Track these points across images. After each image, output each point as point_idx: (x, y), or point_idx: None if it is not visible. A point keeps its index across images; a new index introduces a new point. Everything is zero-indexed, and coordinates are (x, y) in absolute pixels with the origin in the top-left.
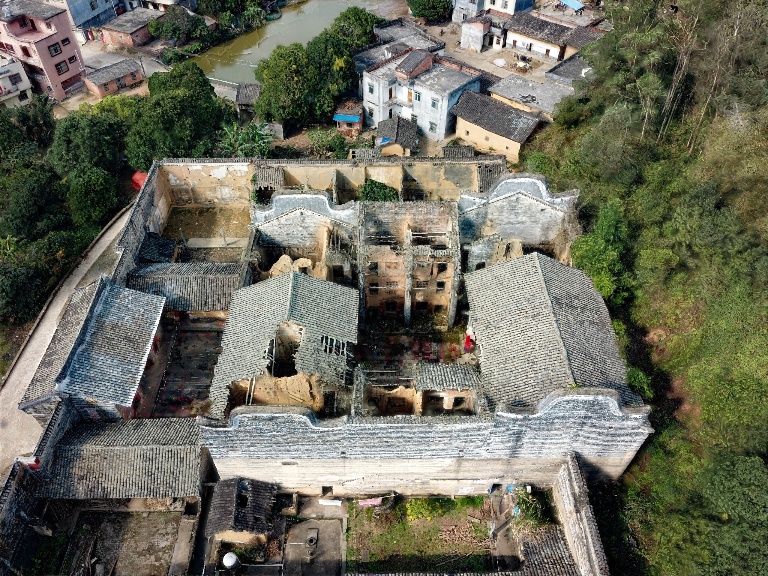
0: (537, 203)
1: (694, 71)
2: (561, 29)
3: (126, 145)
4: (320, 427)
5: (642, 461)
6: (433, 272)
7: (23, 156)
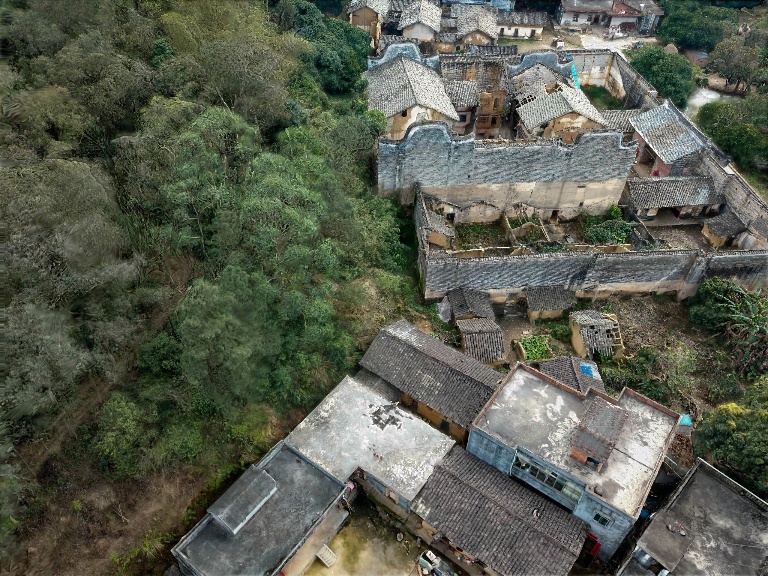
0: None
1: (97, 415)
2: None
3: None
4: None
5: None
6: None
7: None
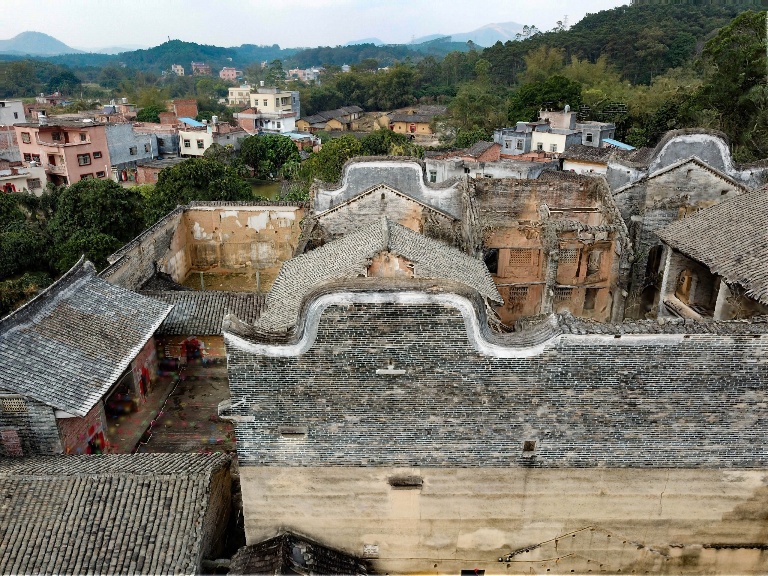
0: (716, 180)
1: None
2: (623, 152)
3: (145, 221)
4: (496, 344)
5: None
6: (580, 271)
7: (18, 229)
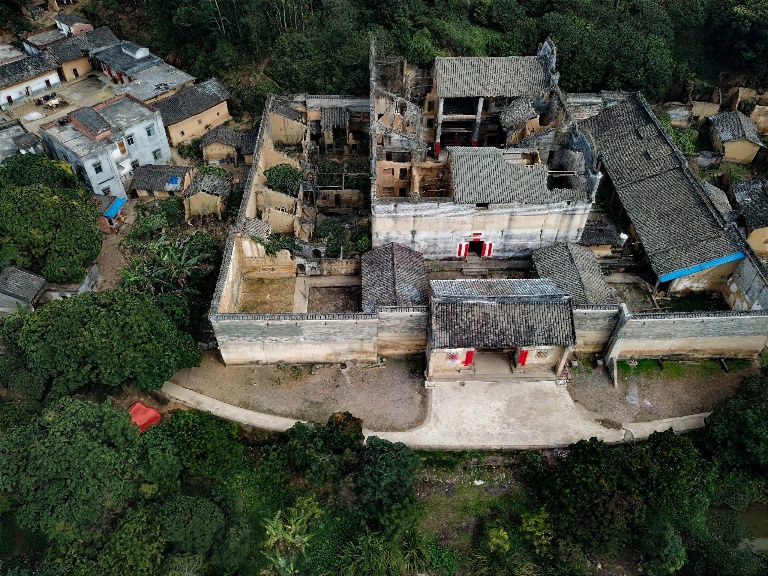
0: None
1: None
2: (37, 58)
3: None
4: None
5: None
6: None
7: (56, 575)
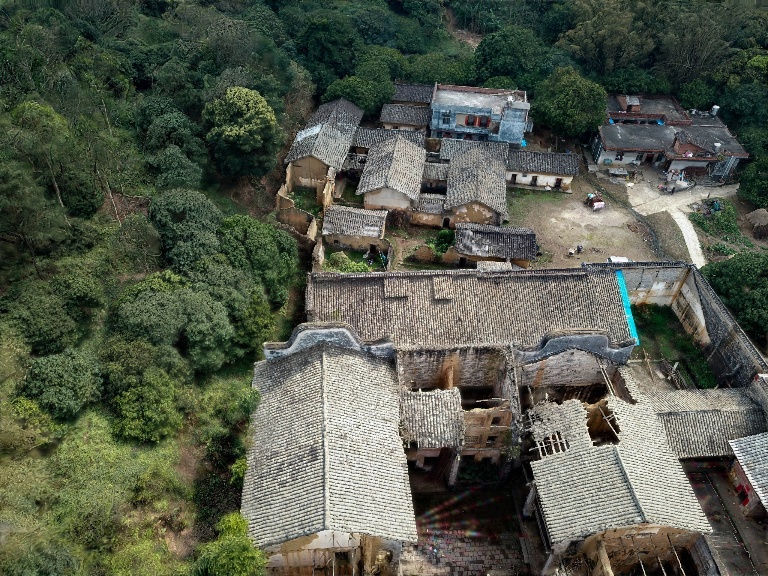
0: None
1: None
2: None
3: None
4: None
5: (242, 425)
6: None
7: None
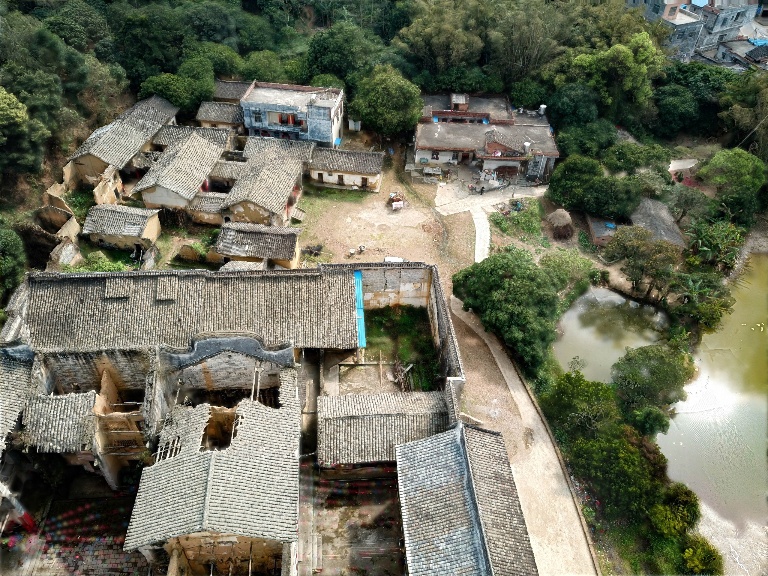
0: None
1: None
2: None
3: None
4: None
5: None
6: None
7: None
